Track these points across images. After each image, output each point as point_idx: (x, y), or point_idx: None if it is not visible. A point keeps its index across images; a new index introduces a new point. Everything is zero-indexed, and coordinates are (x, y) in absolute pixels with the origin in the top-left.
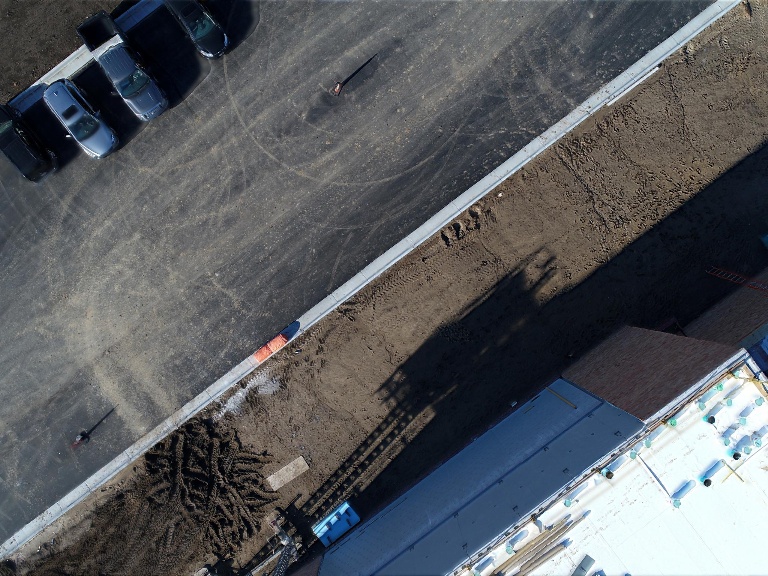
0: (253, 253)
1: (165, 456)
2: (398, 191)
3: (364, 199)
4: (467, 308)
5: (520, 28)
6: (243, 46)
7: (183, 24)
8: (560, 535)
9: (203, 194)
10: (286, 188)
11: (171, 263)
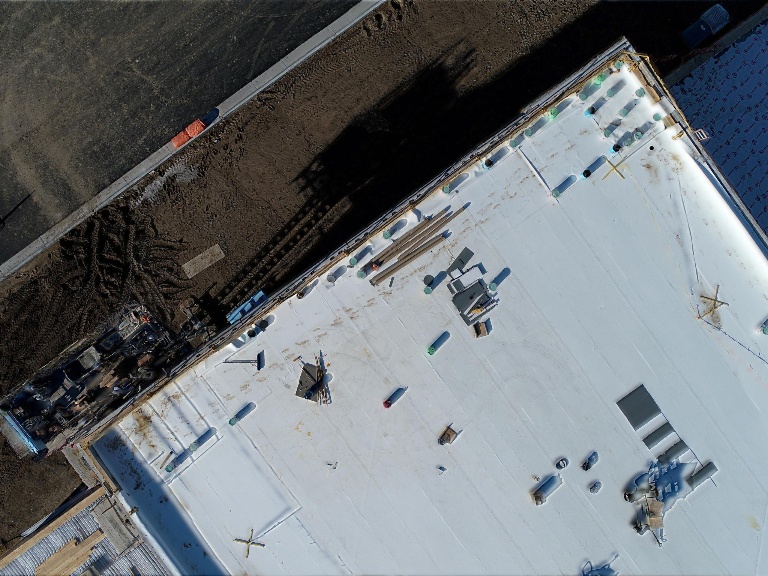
0: (174, 40)
1: (81, 243)
2: None
3: None
4: (387, 98)
5: None
6: None
7: None
8: (439, 225)
9: None
10: None
11: (91, 48)
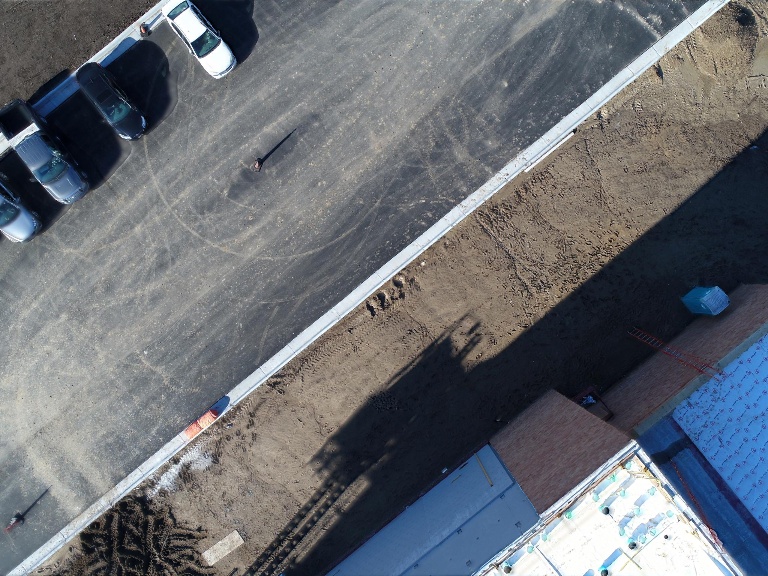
0: (181, 330)
1: (100, 535)
2: (322, 263)
3: (289, 273)
4: (394, 377)
5: (436, 98)
6: (163, 126)
7: (99, 109)
8: None
9: (129, 273)
10: (211, 264)
11: (99, 343)
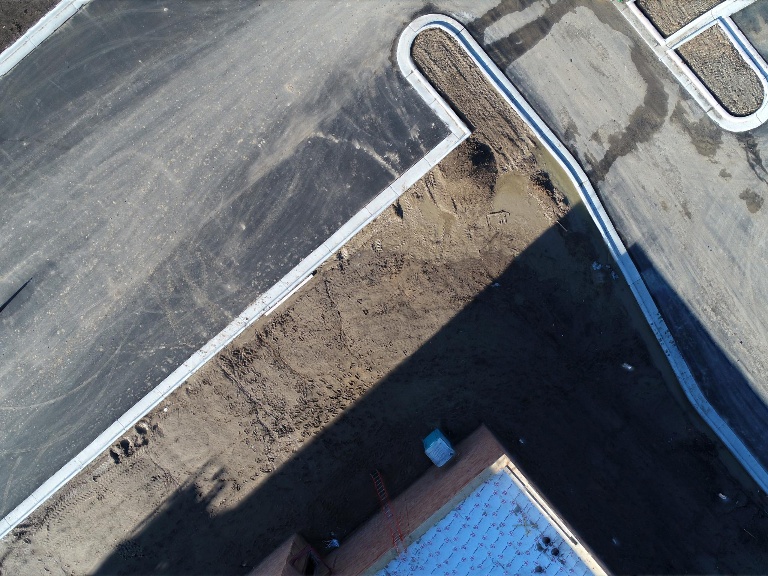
0: None
1: None
2: (63, 412)
3: (30, 422)
4: (139, 525)
5: (174, 243)
6: None
7: None
8: None
9: None
10: None
11: None
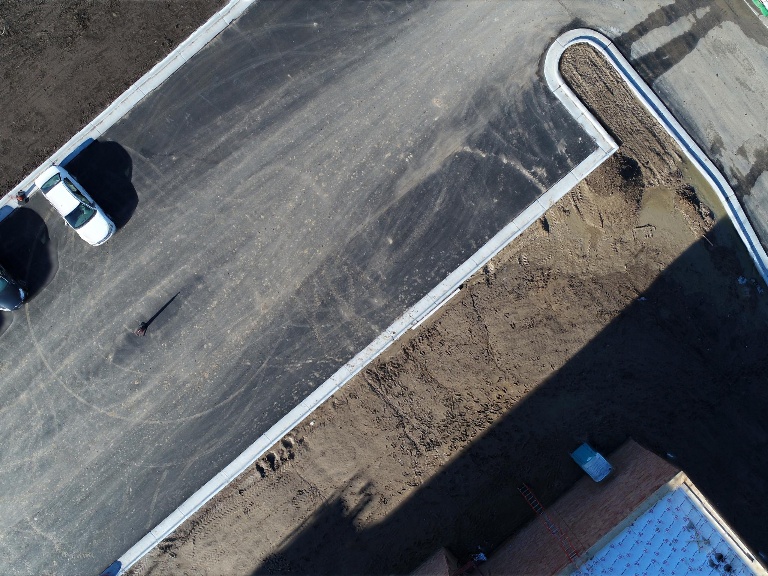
0: (70, 496)
1: None
2: (210, 426)
3: (177, 436)
4: (285, 538)
5: (321, 257)
6: (44, 293)
7: None
8: None
9: (15, 441)
10: (98, 430)
11: None
